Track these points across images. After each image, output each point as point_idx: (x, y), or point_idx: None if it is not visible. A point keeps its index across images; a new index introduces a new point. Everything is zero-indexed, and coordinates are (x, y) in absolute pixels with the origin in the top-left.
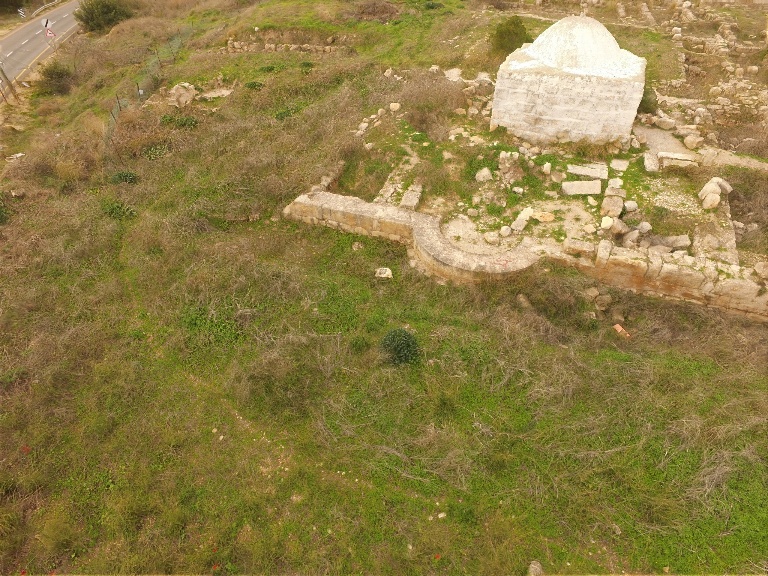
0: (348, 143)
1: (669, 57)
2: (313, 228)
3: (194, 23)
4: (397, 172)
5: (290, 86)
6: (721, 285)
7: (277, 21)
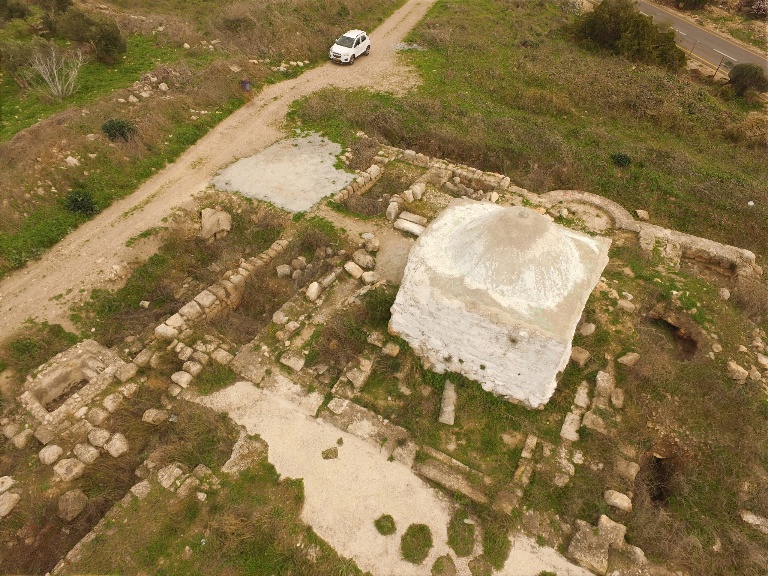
0: None
1: None
2: None
3: None
4: None
5: None
6: None
7: None
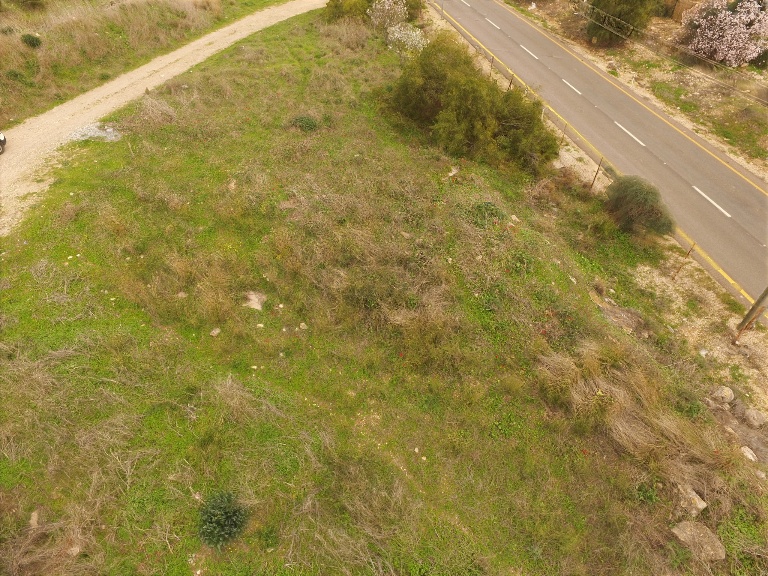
0: None
1: None
2: None
3: None
4: None
5: None
6: None
7: None
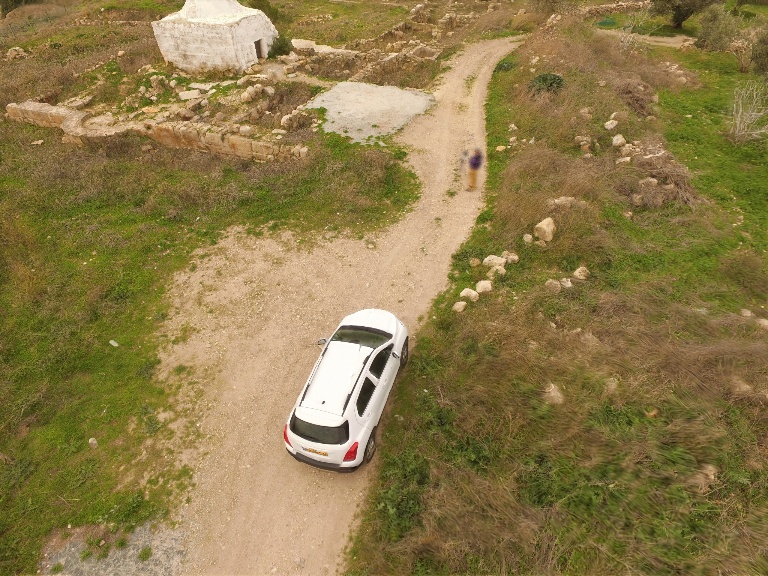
0: (62, 73)
1: (386, 25)
2: (19, 124)
3: (81, 9)
4: (85, 90)
5: (78, 45)
6: (206, 137)
7: (120, 3)
